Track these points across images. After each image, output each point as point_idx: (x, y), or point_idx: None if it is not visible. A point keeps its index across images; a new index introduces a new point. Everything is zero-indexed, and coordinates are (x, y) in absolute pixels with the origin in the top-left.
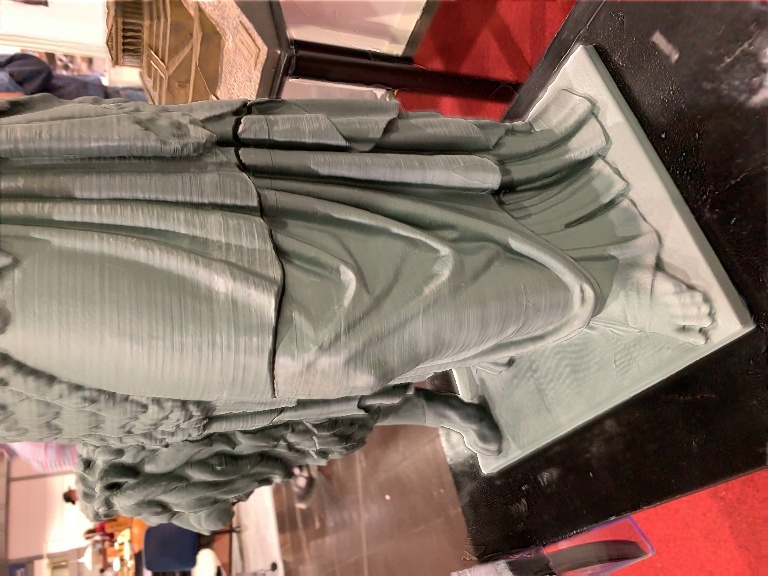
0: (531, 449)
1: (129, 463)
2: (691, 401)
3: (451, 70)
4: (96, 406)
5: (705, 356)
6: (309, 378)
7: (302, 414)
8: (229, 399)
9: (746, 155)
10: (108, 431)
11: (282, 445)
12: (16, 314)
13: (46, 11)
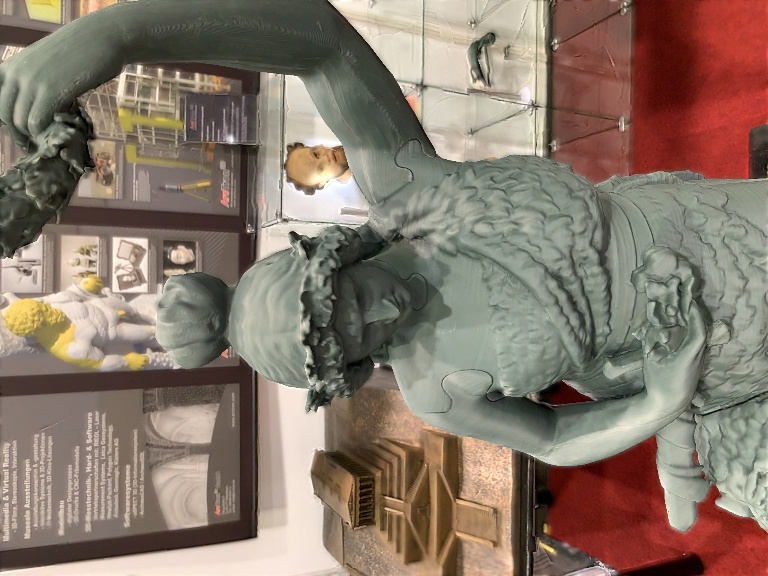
0: None
1: None
2: None
3: (594, 464)
4: None
5: None
6: None
7: None
8: None
9: None
10: None
11: None
12: None
13: (247, 551)
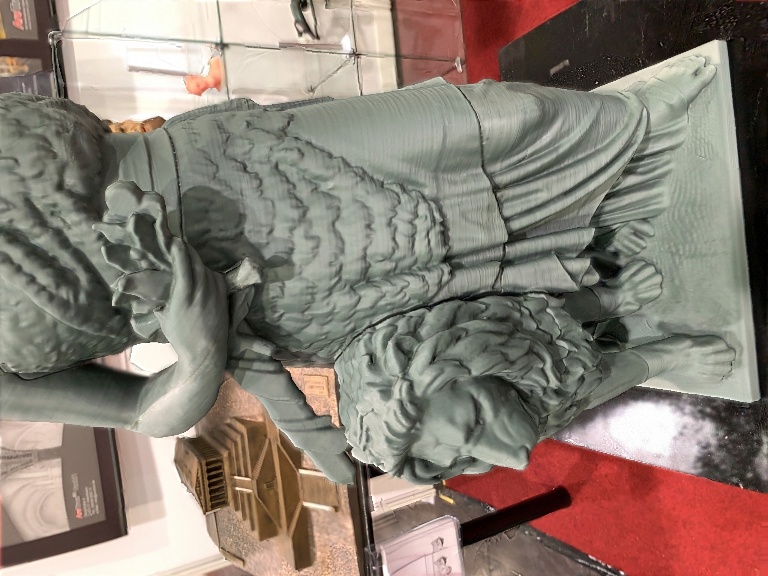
0: (749, 317)
1: (406, 333)
2: (760, 111)
3: None
4: (364, 186)
5: (732, 88)
6: (491, 99)
7: (520, 272)
8: (451, 133)
9: (634, 28)
10: (379, 235)
11: (526, 316)
12: (296, 113)
13: (123, 549)
